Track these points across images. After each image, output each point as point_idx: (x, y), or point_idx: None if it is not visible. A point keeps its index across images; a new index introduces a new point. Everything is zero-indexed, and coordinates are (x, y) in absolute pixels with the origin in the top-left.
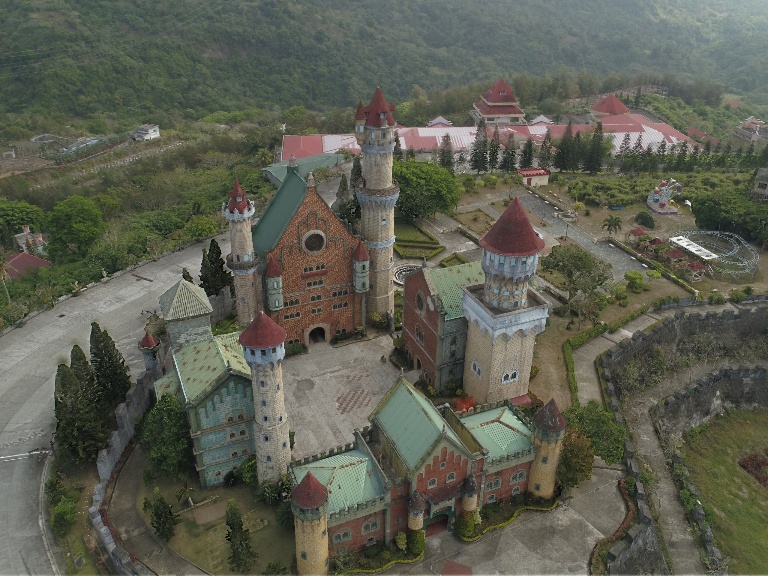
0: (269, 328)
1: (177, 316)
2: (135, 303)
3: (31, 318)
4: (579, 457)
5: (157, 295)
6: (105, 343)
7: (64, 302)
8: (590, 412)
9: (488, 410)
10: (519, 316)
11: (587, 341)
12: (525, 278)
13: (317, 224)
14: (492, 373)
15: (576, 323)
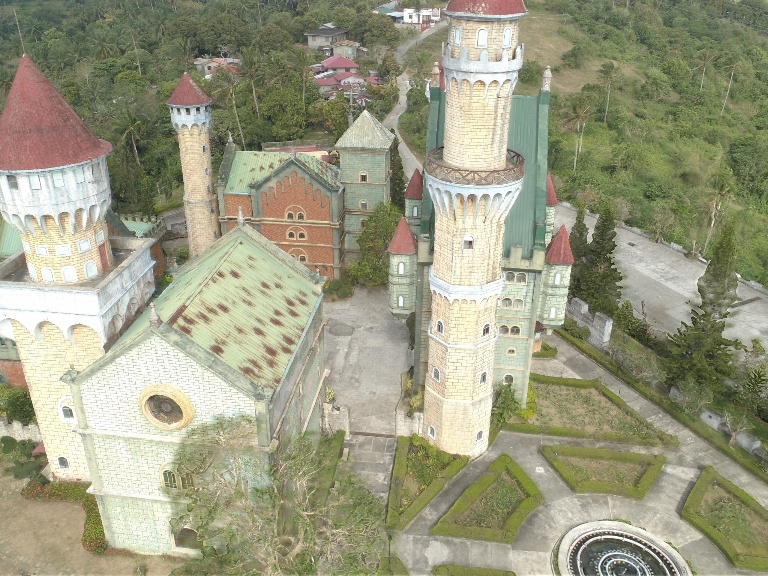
0: None
1: None
2: (653, 284)
3: (631, 231)
4: None
5: (676, 300)
6: None
7: (670, 249)
8: None
9: None
10: (24, 264)
11: None
12: None
13: None
14: None
15: None
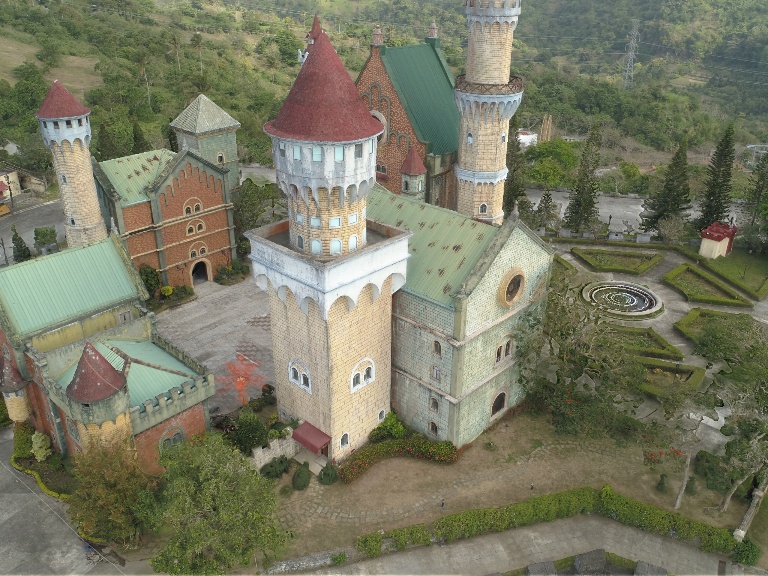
0: (50, 99)
1: (177, 125)
2: None
3: None
4: (75, 470)
5: None
6: (176, 143)
7: None
8: (193, 458)
9: (189, 366)
10: (283, 258)
11: (669, 536)
12: (305, 194)
13: (379, 103)
14: (276, 347)
15: (696, 496)
